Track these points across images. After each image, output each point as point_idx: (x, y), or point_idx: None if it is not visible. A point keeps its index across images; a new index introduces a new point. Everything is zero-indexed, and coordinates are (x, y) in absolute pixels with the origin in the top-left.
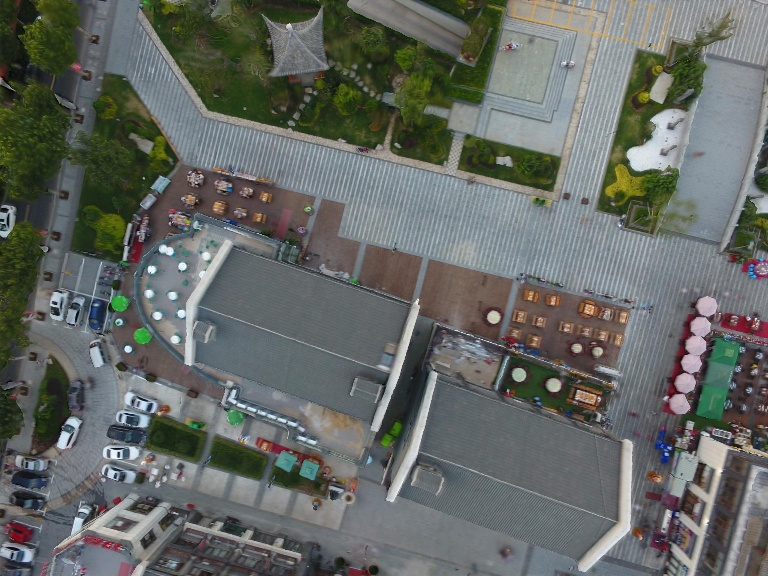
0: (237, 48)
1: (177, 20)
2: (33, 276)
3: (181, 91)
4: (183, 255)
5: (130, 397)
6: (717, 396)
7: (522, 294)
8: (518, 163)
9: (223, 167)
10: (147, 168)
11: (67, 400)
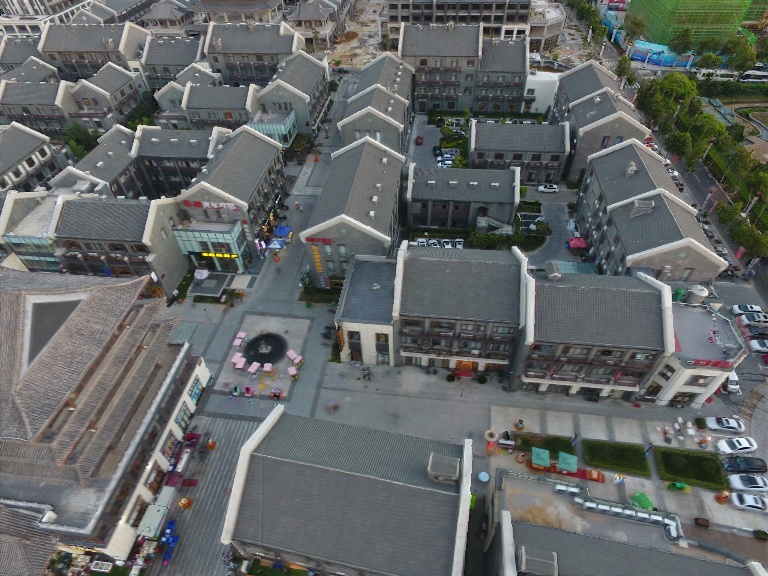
0: None
1: None
2: None
3: None
4: None
5: None
6: None
7: None
8: None
9: None
10: None
11: None
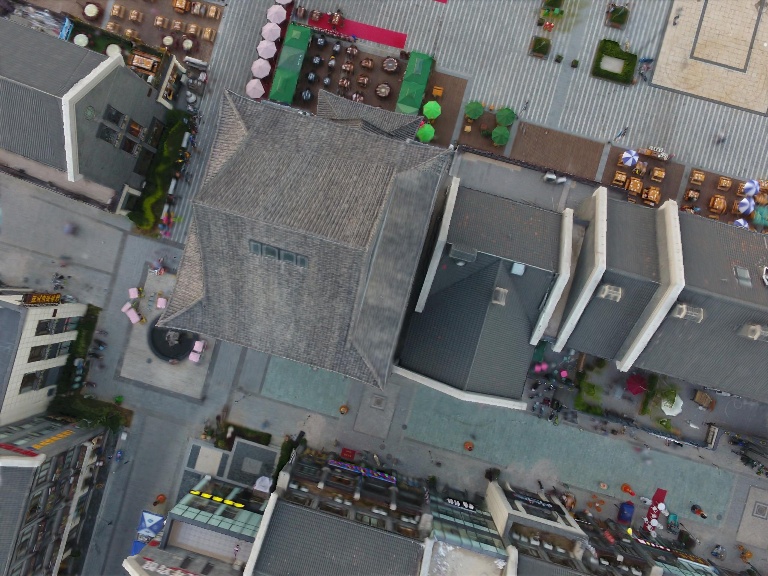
0: None
1: None
2: None
3: None
4: None
5: None
6: (284, 76)
7: None
8: None
9: None
10: None
11: None
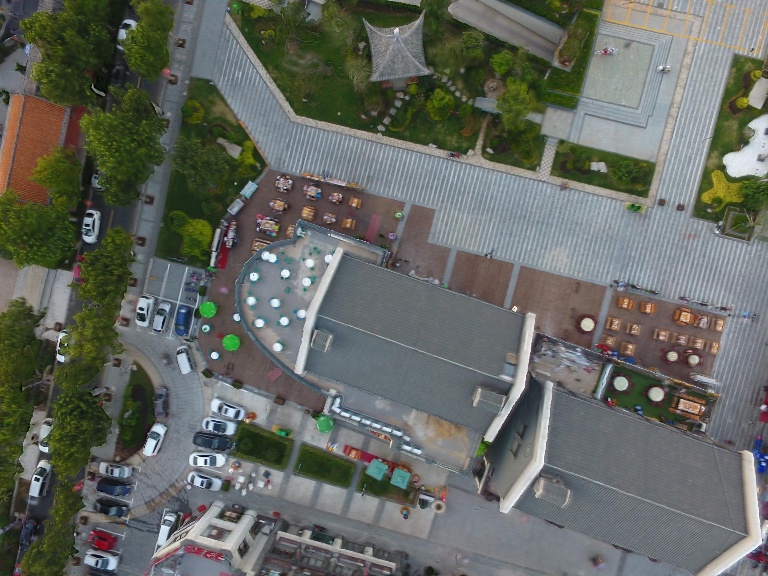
0: (327, 52)
1: (265, 24)
2: (126, 282)
3: (269, 95)
4: (285, 262)
5: (217, 404)
6: None
7: (616, 301)
8: (613, 169)
9: (311, 172)
10: (234, 173)
11: (153, 407)
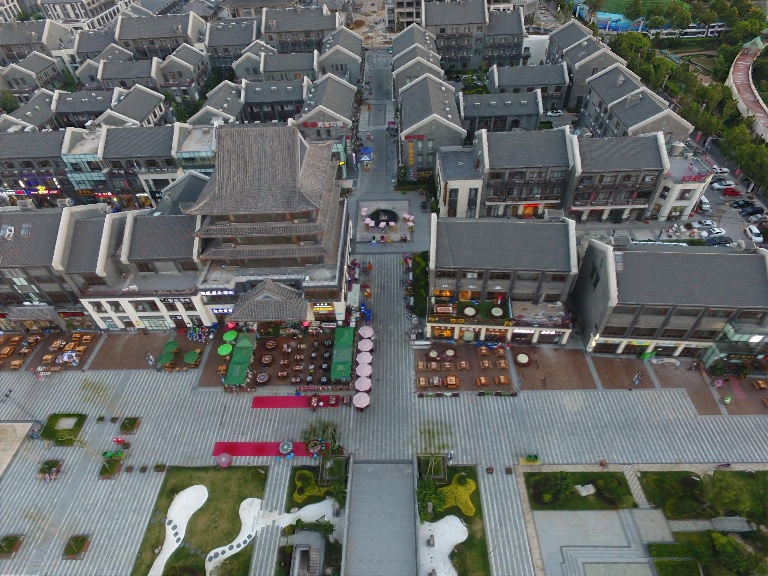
0: None
1: None
2: None
3: None
4: None
5: None
6: (344, 339)
7: (509, 380)
8: None
9: None
10: None
11: None
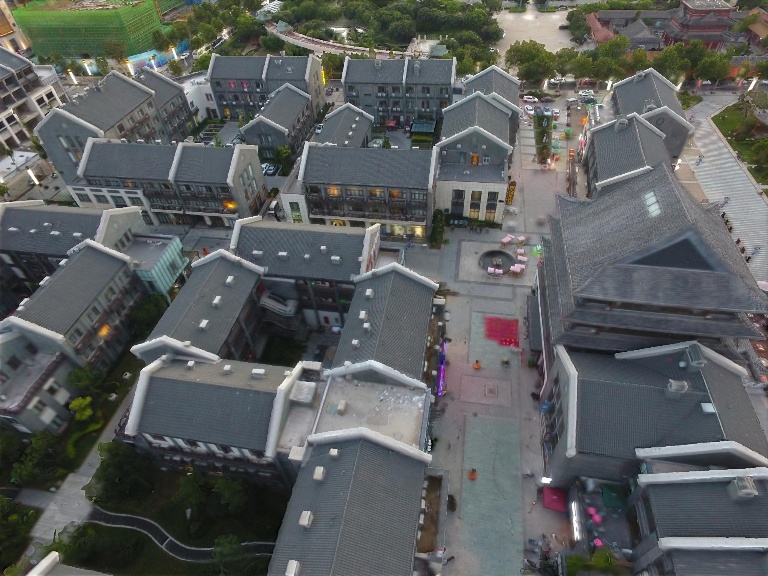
0: None
1: None
2: (605, 76)
3: None
4: None
5: None
6: None
7: None
8: None
9: None
10: None
11: (546, 96)
